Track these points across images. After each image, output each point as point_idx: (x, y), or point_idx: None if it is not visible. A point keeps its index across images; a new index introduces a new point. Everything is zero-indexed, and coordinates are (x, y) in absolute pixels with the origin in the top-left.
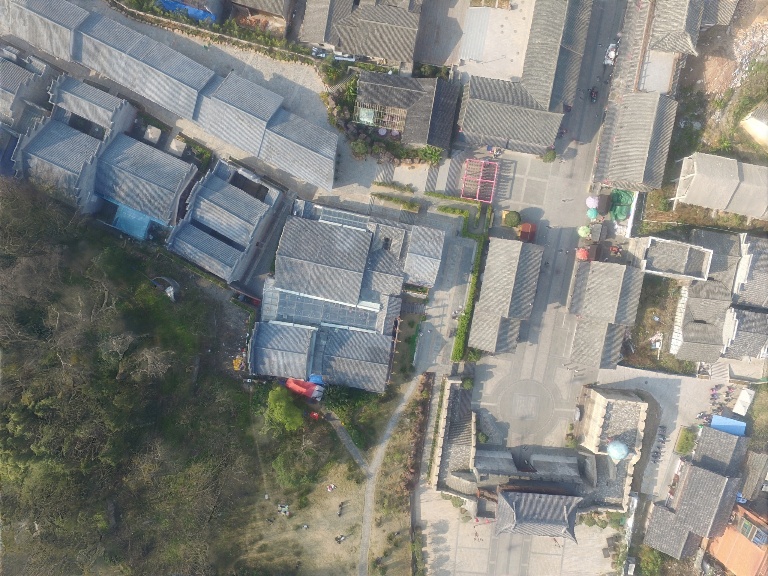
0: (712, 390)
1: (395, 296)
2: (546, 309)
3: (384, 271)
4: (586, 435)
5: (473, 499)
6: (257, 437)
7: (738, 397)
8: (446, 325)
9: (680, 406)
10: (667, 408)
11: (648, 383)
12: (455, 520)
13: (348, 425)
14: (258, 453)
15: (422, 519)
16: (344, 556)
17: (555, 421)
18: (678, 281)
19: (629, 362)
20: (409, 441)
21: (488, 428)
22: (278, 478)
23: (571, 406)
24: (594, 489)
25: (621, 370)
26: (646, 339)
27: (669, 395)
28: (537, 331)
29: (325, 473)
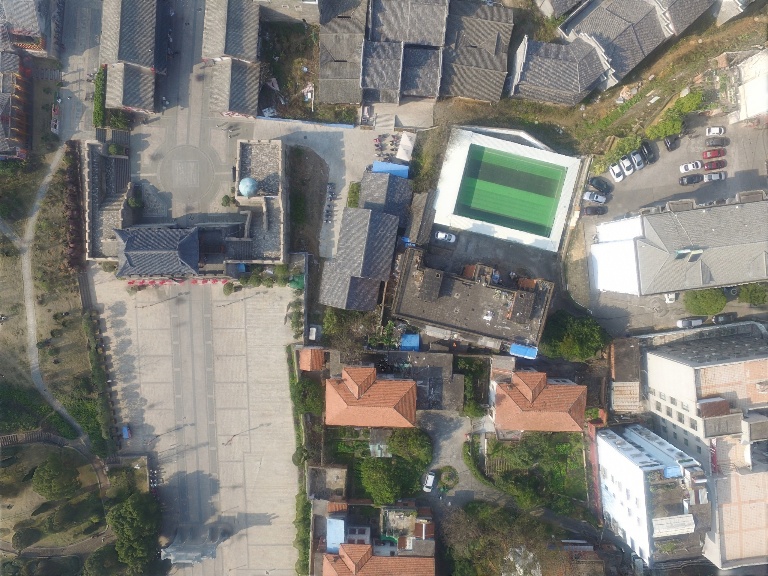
0: (375, 139)
1: (10, 52)
2: (192, 70)
3: None
4: None
5: None
6: None
7: (400, 142)
8: (84, 90)
9: (347, 161)
10: (333, 164)
11: (307, 138)
12: (132, 301)
13: None
14: None
15: (98, 302)
16: (11, 339)
17: (217, 186)
18: None
19: (279, 114)
20: (64, 214)
21: (151, 200)
22: None
23: None
24: (242, 238)
25: (276, 126)
26: (298, 91)
27: (333, 150)
28: (186, 94)
29: None
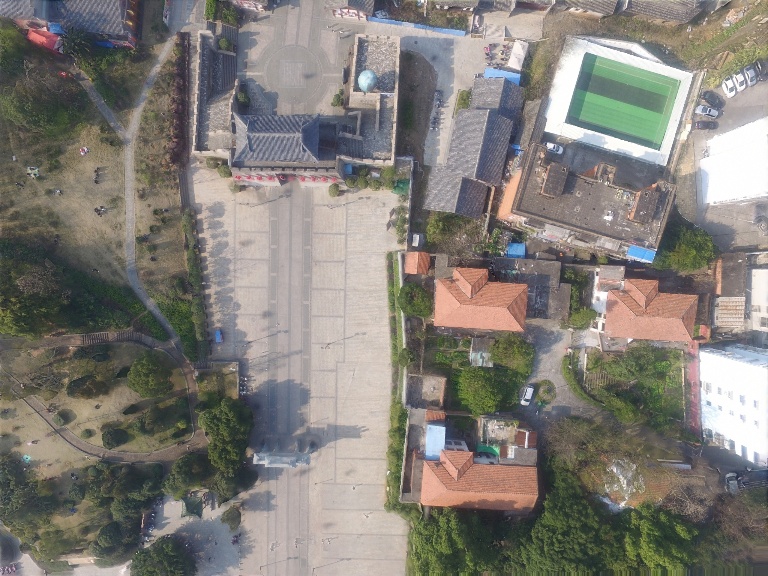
0: (486, 48)
1: None
2: None
3: None
4: None
5: (227, 149)
6: None
7: None
8: None
9: (456, 69)
10: (442, 71)
11: (418, 43)
12: (231, 202)
13: None
14: (2, 111)
15: (196, 202)
16: (108, 233)
17: (324, 88)
18: None
19: None
20: (169, 107)
21: (256, 99)
22: (7, 113)
23: (340, 71)
24: (355, 135)
25: (388, 29)
26: None
27: (443, 57)
28: None
29: (77, 135)
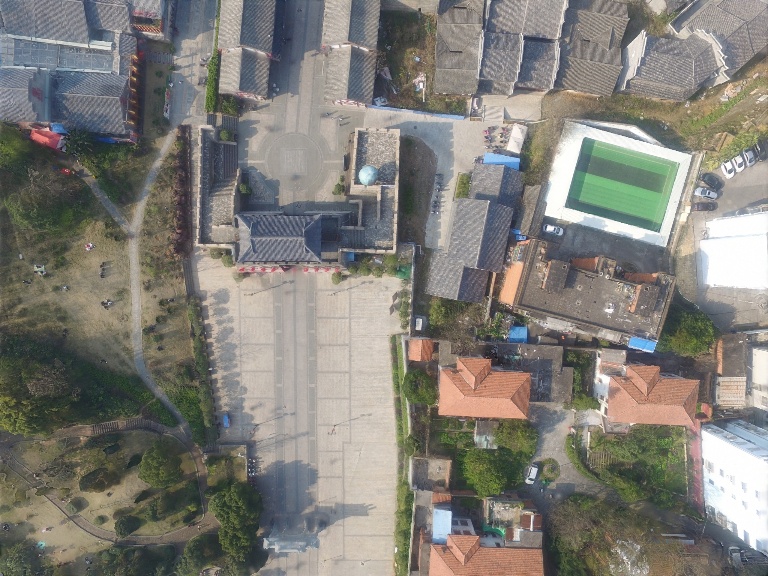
0: (485, 131)
1: (128, 34)
2: (304, 58)
3: (107, 2)
4: (351, 179)
5: None
6: (5, 193)
7: None
8: (196, 74)
9: (455, 152)
10: (442, 155)
11: (417, 128)
12: (235, 288)
13: (99, 178)
14: (8, 211)
15: (201, 289)
16: (115, 324)
17: (325, 174)
18: (434, 17)
19: (391, 103)
20: (172, 199)
21: (258, 187)
22: (13, 218)
23: (340, 157)
24: (357, 227)
25: (387, 115)
26: (409, 81)
27: (442, 141)
28: (297, 81)
29: (82, 231)
